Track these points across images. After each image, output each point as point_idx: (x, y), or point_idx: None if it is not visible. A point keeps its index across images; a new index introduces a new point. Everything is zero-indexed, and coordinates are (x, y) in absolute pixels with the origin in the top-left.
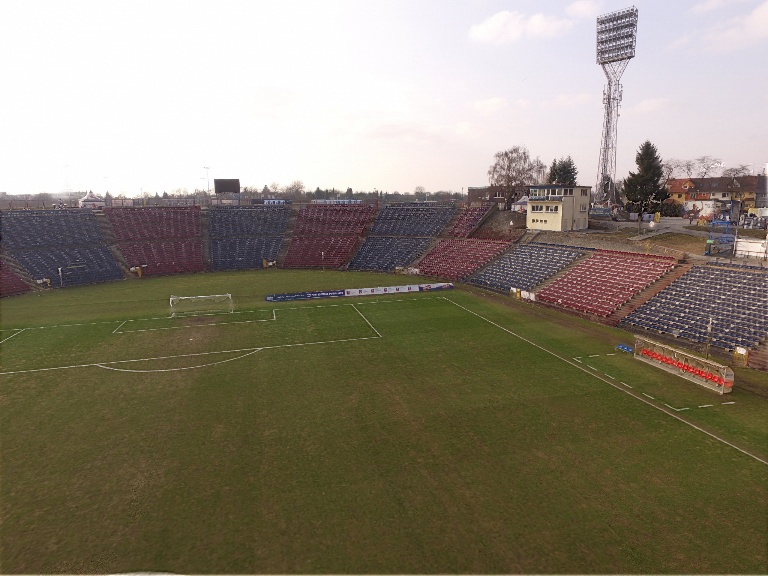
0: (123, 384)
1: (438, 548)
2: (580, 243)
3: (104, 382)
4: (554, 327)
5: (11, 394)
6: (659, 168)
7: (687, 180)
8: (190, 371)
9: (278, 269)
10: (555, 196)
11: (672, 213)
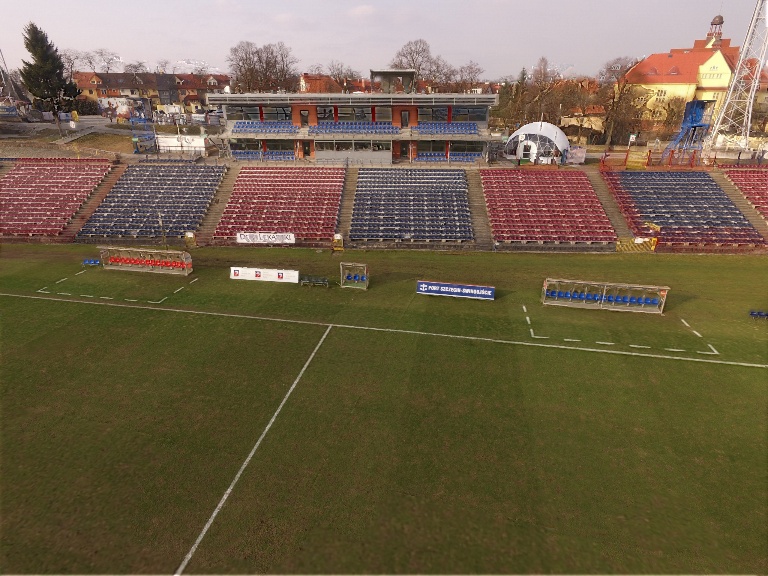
0: None
1: None
2: None
3: None
4: None
5: None
6: (57, 59)
7: (92, 74)
8: None
9: None
10: None
11: (89, 111)
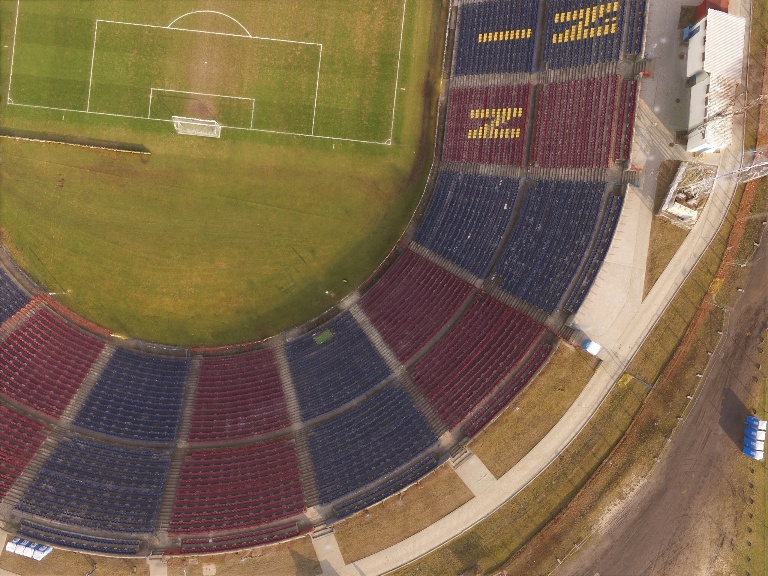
0: (233, 1)
1: None
2: None
3: (242, 7)
4: None
5: (278, 8)
6: None
7: None
8: (205, 5)
9: (114, 331)
10: None
11: None
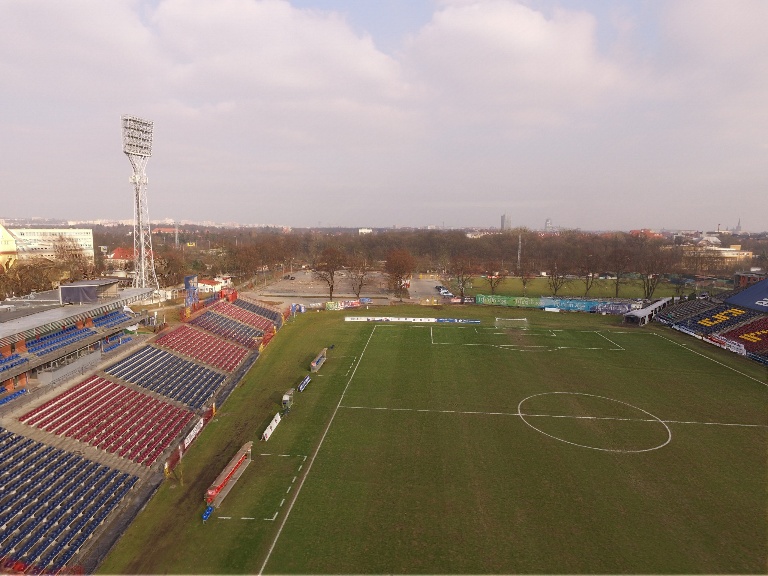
0: None
1: None
2: None
3: None
4: None
5: None
6: None
7: None
8: None
9: None
10: None
11: None
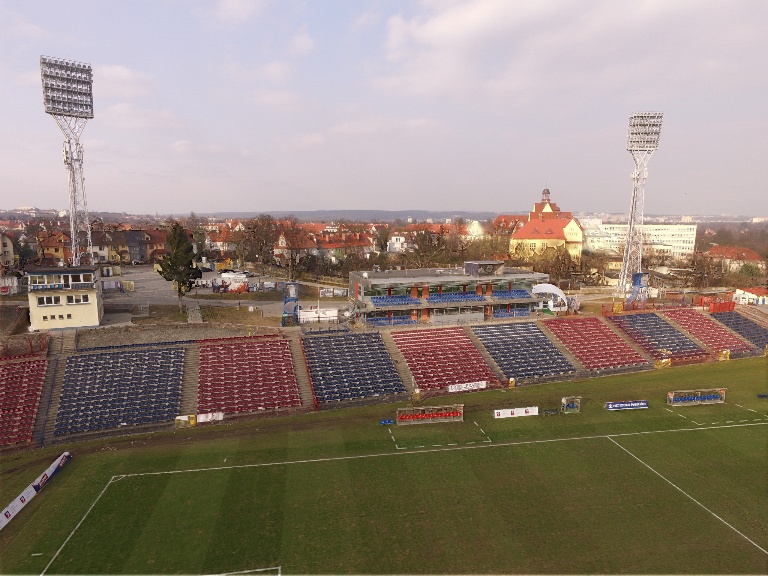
0: None
1: (702, 575)
2: (159, 337)
3: None
4: (309, 434)
5: None
6: None
7: (60, 233)
8: None
9: None
10: (80, 283)
11: None
